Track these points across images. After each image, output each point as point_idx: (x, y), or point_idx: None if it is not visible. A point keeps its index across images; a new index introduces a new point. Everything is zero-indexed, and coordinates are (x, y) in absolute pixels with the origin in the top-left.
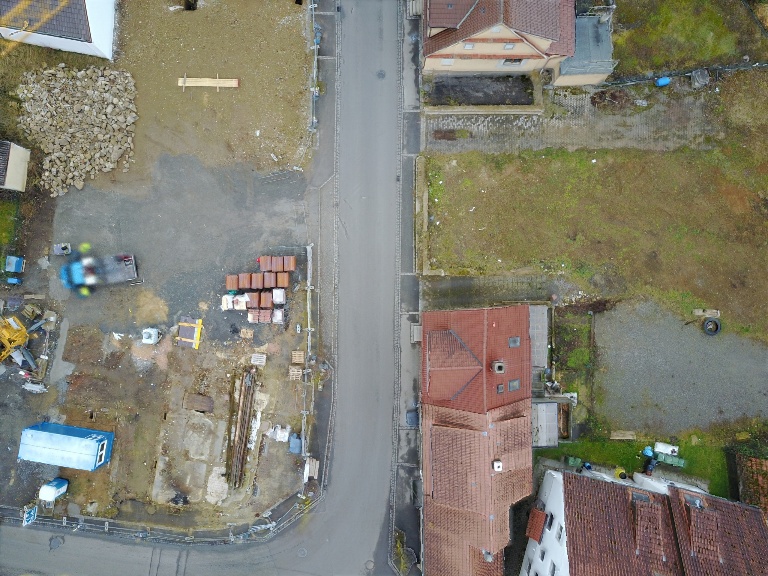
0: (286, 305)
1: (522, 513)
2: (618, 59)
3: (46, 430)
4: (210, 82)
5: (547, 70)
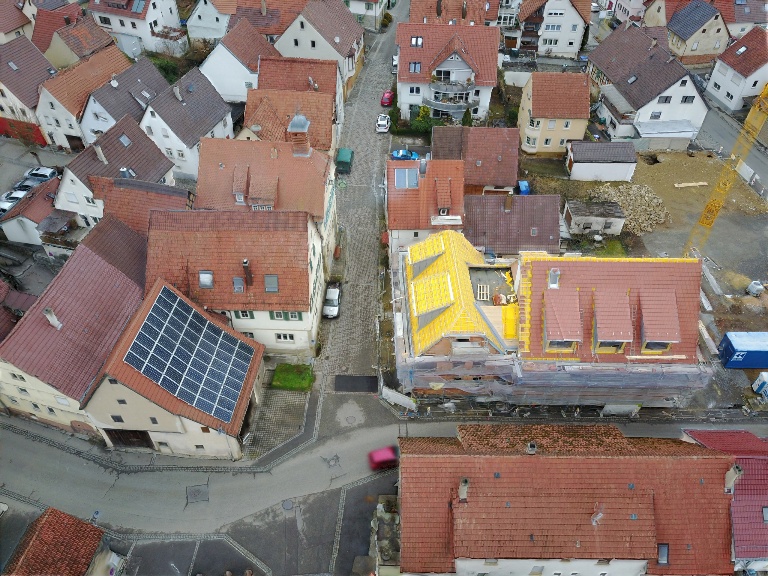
0: None
1: None
2: None
3: None
4: (692, 184)
5: None
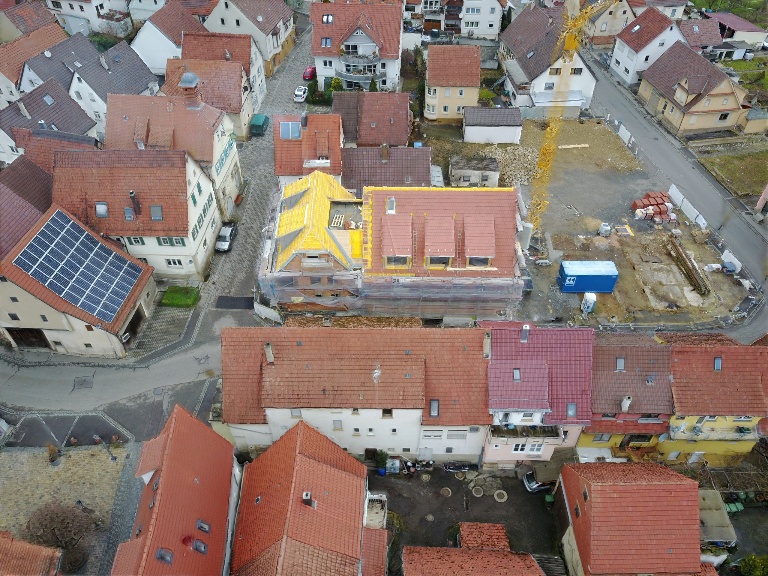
0: None
1: None
2: None
3: None
4: (574, 146)
5: (738, 126)
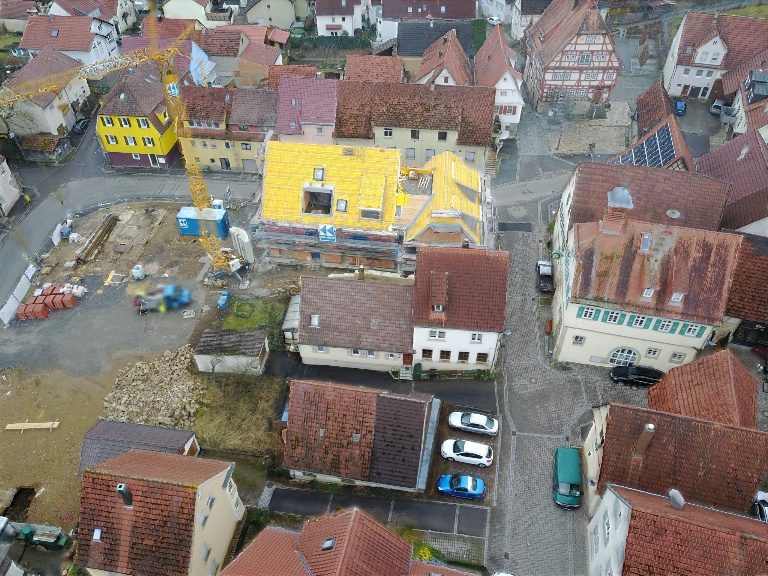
0: None
1: None
2: None
3: (223, 233)
4: (31, 425)
5: None
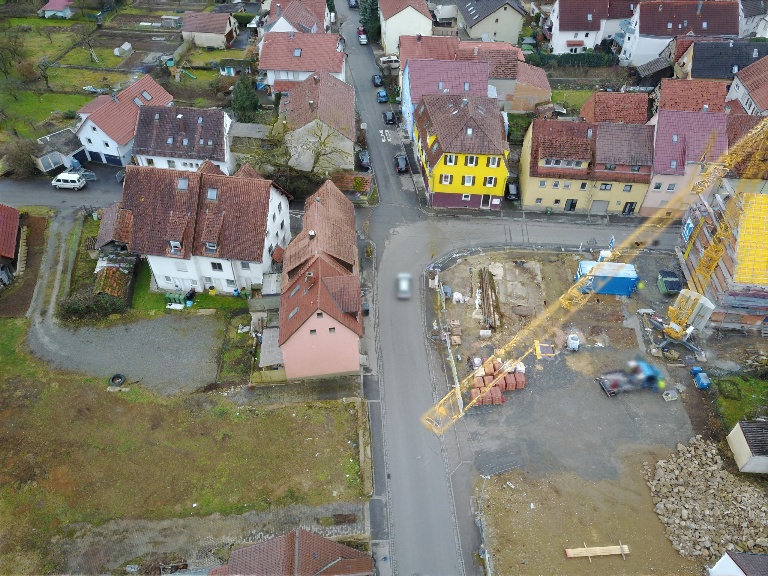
0: None
1: None
2: (162, 567)
3: (626, 291)
4: (596, 551)
5: None
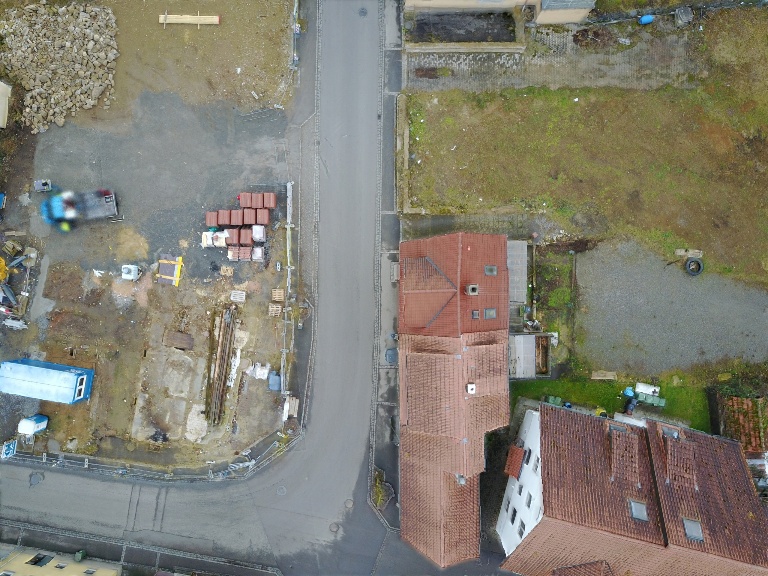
0: (266, 243)
1: (502, 453)
2: None
3: None
4: (191, 19)
5: (529, 7)
